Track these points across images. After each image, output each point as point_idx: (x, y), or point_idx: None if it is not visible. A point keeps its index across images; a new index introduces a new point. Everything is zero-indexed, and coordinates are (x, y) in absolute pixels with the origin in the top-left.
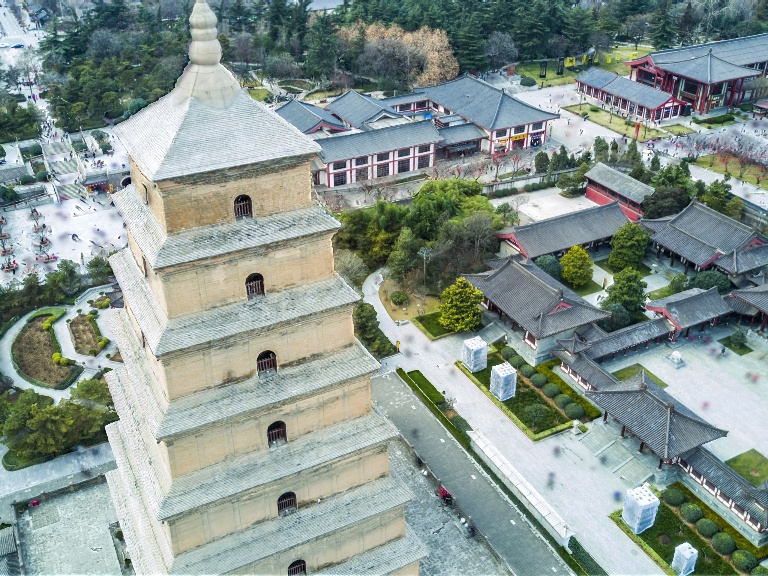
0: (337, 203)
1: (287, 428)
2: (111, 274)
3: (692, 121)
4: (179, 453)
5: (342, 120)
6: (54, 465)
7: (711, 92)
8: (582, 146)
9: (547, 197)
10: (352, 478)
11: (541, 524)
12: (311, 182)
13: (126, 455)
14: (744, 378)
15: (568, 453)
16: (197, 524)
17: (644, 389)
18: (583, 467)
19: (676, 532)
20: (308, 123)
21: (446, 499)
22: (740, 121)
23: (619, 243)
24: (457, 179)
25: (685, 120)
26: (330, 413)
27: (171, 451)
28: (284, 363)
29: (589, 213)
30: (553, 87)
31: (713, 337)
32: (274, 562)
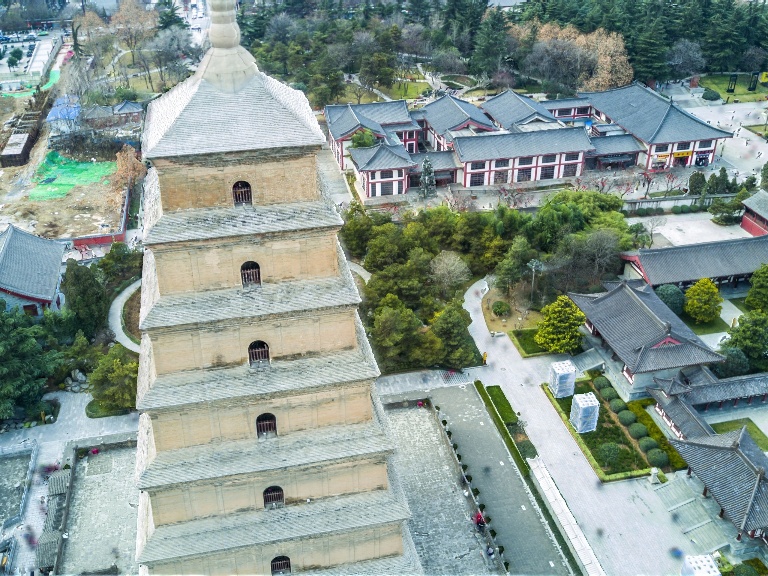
0: (463, 203)
1: (277, 421)
2: None
3: None
4: (164, 428)
5: (494, 120)
6: (128, 419)
7: None
8: (755, 170)
9: (696, 222)
10: (345, 484)
11: (582, 572)
12: (432, 179)
13: None
14: None
15: (638, 502)
16: (178, 500)
17: (735, 447)
18: (650, 520)
19: None
20: (456, 120)
21: (479, 525)
22: None
23: (758, 281)
24: (595, 192)
25: None
26: (325, 414)
27: (155, 424)
28: (277, 356)
29: (732, 244)
30: (740, 103)
31: None
32: (256, 553)
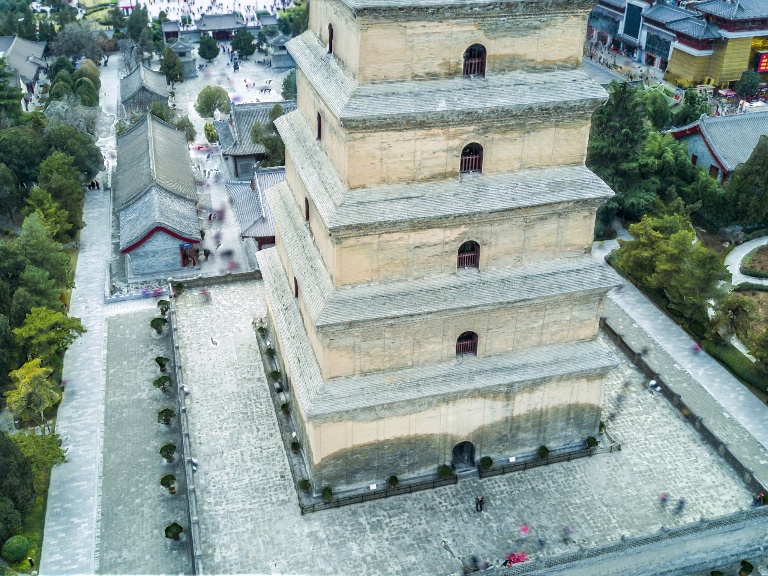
0: None
1: None
2: None
3: None
4: None
5: None
6: None
7: None
8: None
9: None
10: None
11: None
12: None
13: None
14: None
15: None
16: None
17: None
18: None
19: None
20: None
21: None
22: None
23: None
24: None
25: None
26: None
27: None
28: None
29: None
30: None
31: None
32: None
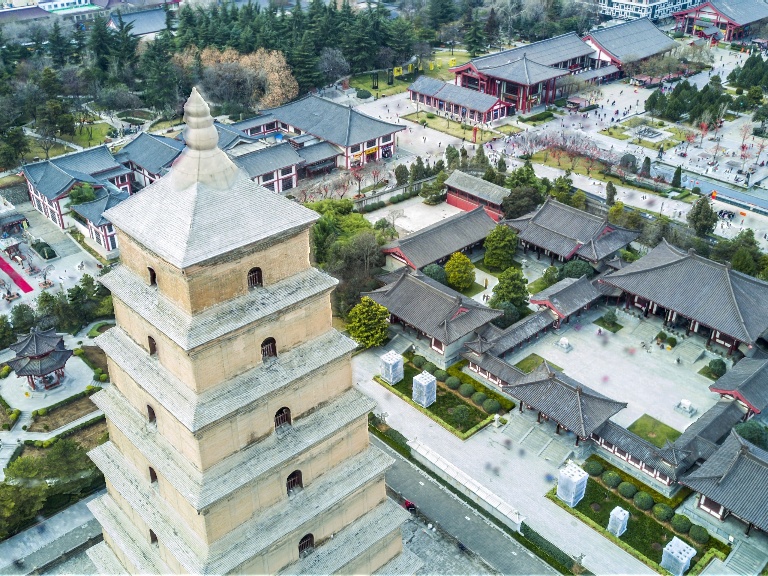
0: None
1: (303, 475)
2: (1, 341)
3: (518, 120)
4: (214, 519)
5: None
6: None
7: (530, 92)
8: (429, 153)
9: (413, 207)
10: (358, 509)
11: (492, 515)
12: None
13: (123, 529)
14: (622, 352)
15: (496, 446)
16: None
17: (553, 377)
18: (512, 456)
19: (603, 499)
20: (165, 156)
21: (410, 509)
22: (558, 117)
23: (493, 245)
24: None
25: (512, 120)
26: (337, 454)
27: (207, 519)
28: (297, 416)
29: (460, 220)
30: (387, 97)
31: (589, 320)
32: None
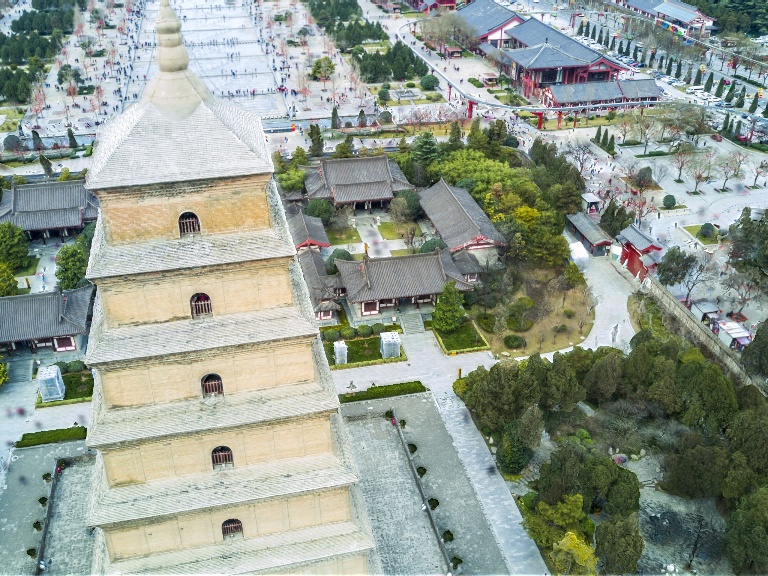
0: None
1: None
2: None
3: None
4: None
5: None
6: None
7: None
8: None
9: None
10: None
11: None
12: None
13: (171, 567)
14: None
15: None
16: None
17: None
18: None
19: None
20: None
21: None
22: None
23: (7, 245)
24: None
25: None
26: None
27: None
28: None
29: None
30: None
31: None
32: None
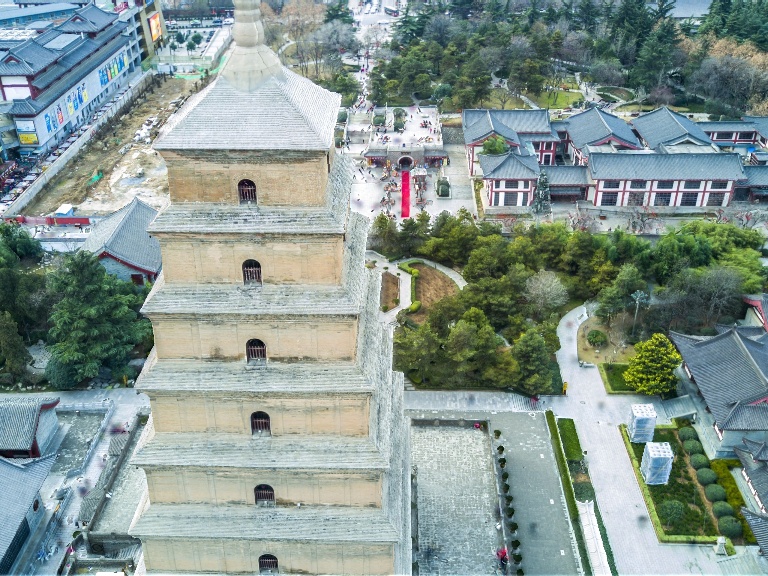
0: (583, 223)
1: (271, 421)
2: None
3: None
4: (162, 410)
5: (642, 137)
6: None
7: None
8: None
9: None
10: (337, 495)
11: None
12: (547, 194)
13: None
14: None
15: (695, 571)
16: (173, 481)
17: None
18: None
19: None
20: (597, 134)
21: (502, 562)
22: None
23: None
24: (732, 225)
25: None
26: (319, 421)
27: (154, 405)
28: (274, 356)
29: None
30: None
31: None
32: (244, 546)
